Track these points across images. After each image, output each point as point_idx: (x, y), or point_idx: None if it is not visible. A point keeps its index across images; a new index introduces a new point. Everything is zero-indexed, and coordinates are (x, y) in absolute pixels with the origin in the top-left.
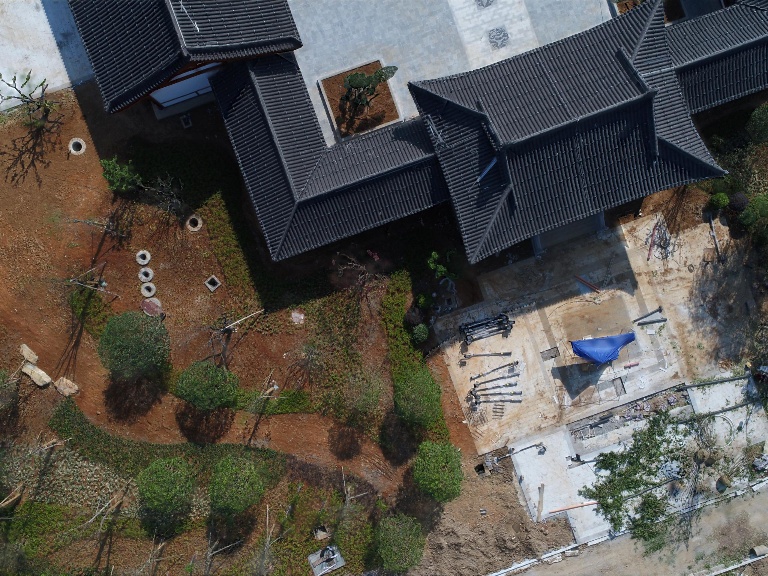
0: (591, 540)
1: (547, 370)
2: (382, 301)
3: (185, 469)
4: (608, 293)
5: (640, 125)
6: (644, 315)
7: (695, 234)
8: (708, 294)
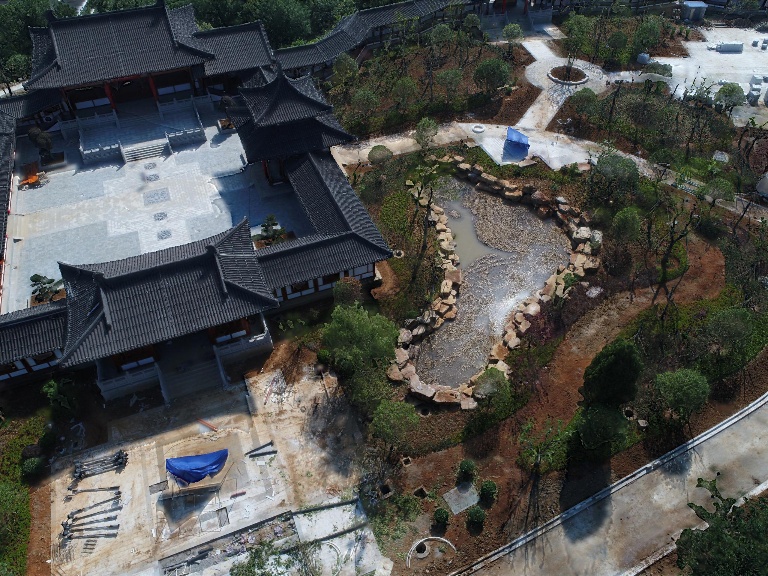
0: None
1: (152, 503)
2: (8, 442)
3: None
4: (225, 431)
5: (213, 275)
6: (256, 448)
7: (308, 384)
8: (318, 429)
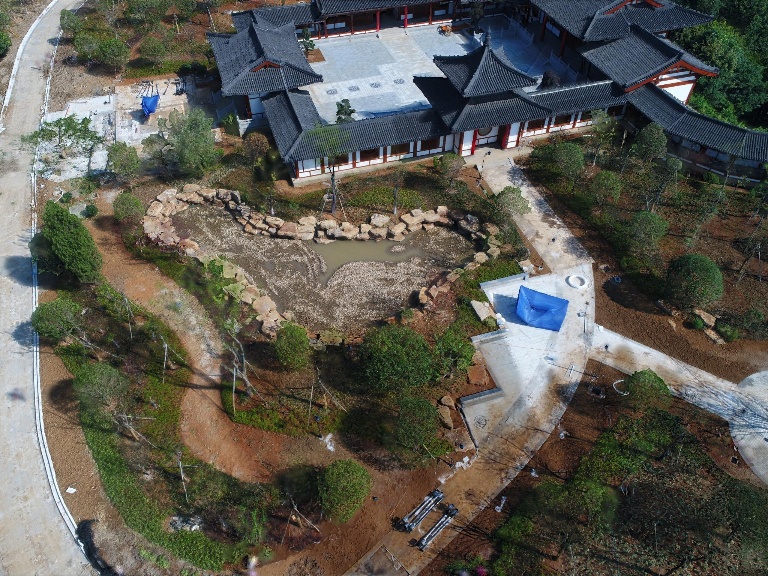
0: (45, 117)
1: None
2: None
3: (153, 2)
4: None
5: None
6: (164, 134)
7: None
8: None
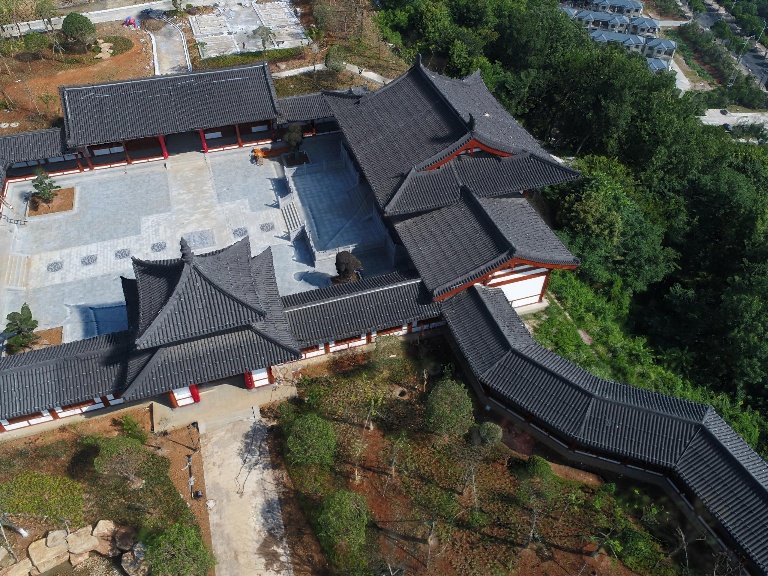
0: None
1: None
2: None
3: None
4: None
5: None
6: None
7: None
8: None
